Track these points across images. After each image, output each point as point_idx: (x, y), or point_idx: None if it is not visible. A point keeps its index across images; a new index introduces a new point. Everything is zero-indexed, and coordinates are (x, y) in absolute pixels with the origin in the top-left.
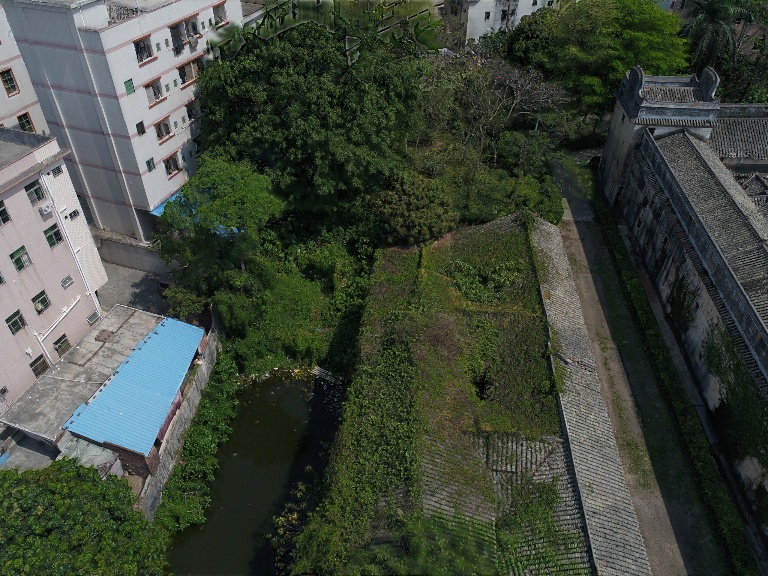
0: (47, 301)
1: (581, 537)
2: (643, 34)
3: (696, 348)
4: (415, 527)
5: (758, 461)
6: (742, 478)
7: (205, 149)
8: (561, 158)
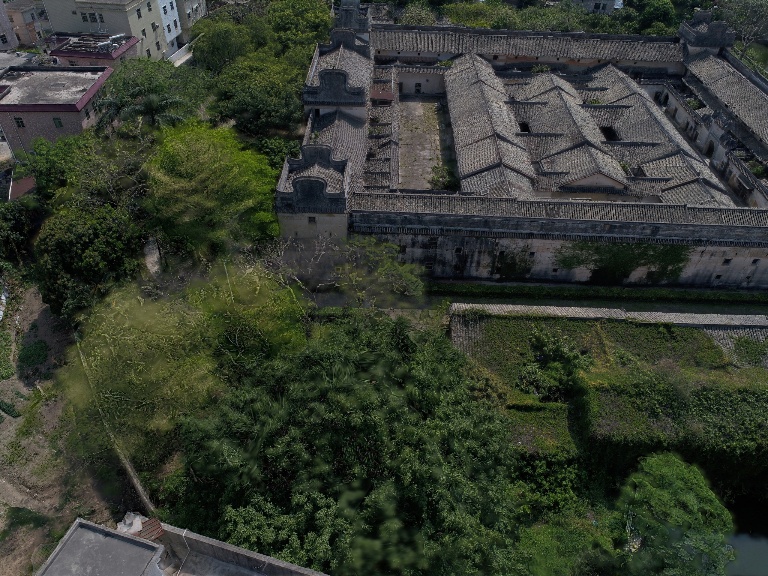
0: None
1: (766, 330)
2: (233, 156)
3: (548, 270)
4: None
5: (643, 266)
6: (633, 282)
7: None
8: None
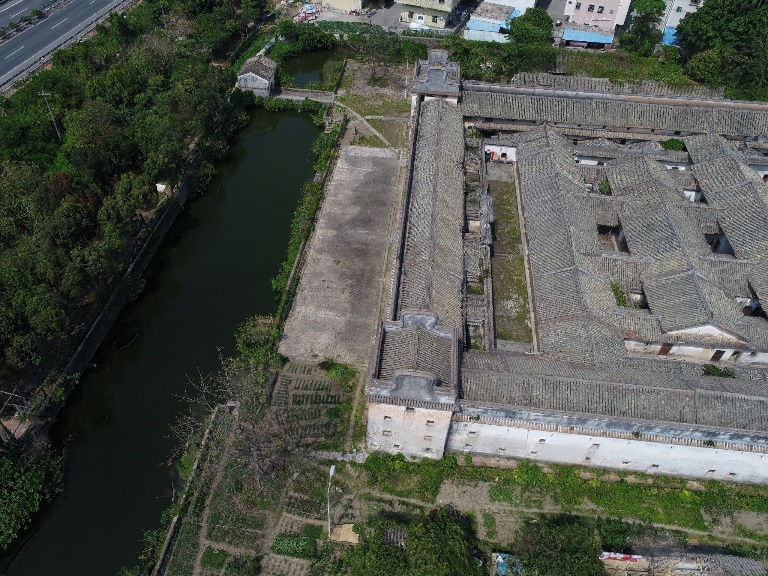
0: (602, 11)
1: None
2: None
3: None
4: None
5: None
6: None
7: None
8: None
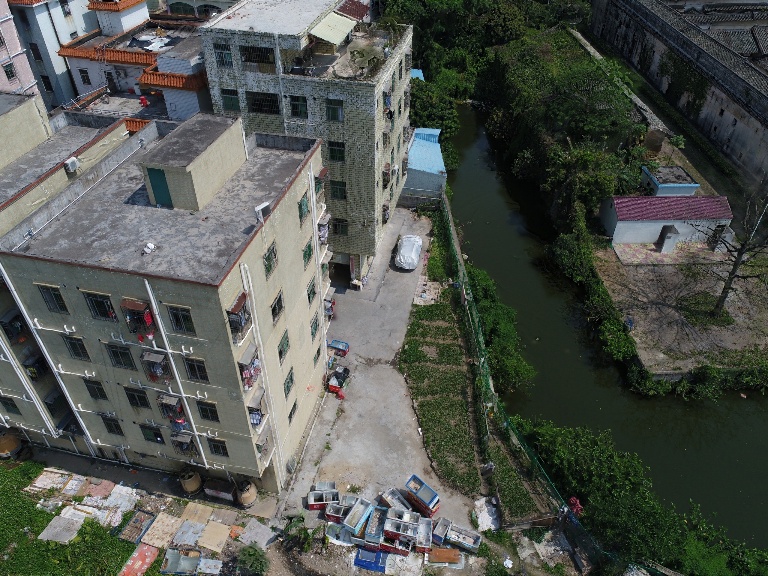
0: None
1: None
2: None
3: (655, 72)
4: (562, 86)
5: (686, 92)
6: (680, 107)
7: (385, 0)
8: (575, 0)
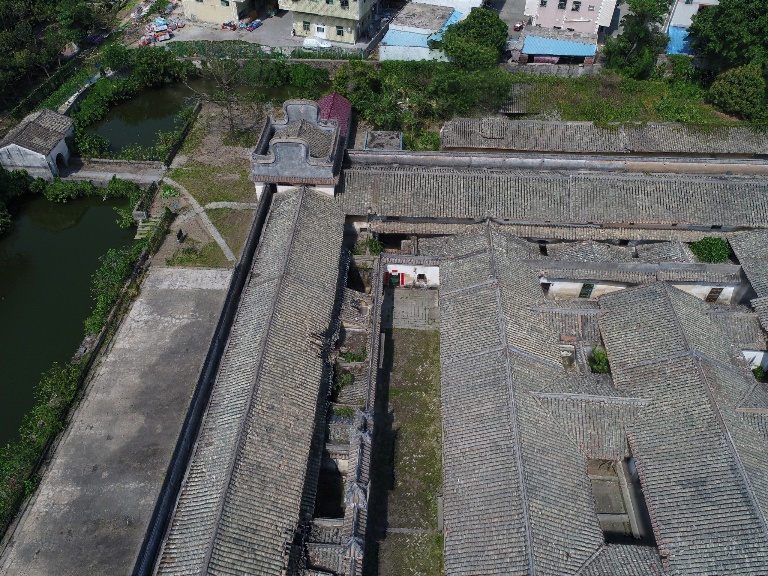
0: (579, 8)
1: None
2: None
3: None
4: (502, 76)
5: None
6: None
7: None
8: None
